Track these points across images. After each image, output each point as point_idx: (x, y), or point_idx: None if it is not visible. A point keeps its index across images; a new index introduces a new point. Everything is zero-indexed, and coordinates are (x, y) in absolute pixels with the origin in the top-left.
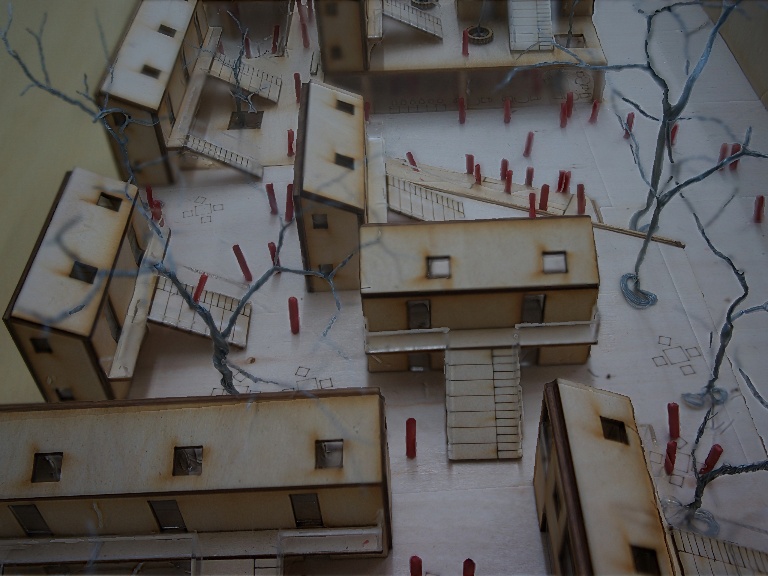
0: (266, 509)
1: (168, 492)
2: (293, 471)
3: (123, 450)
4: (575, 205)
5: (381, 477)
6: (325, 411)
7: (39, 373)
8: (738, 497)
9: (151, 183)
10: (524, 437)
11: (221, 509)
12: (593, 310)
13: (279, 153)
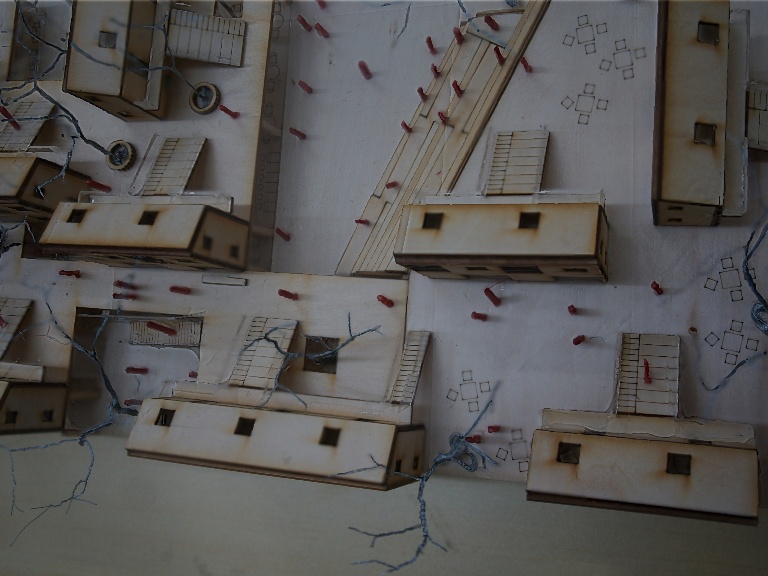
0: None
1: None
2: None
3: None
4: (485, 32)
5: None
6: None
7: None
8: None
9: (422, 449)
10: None
11: None
12: None
13: (386, 316)
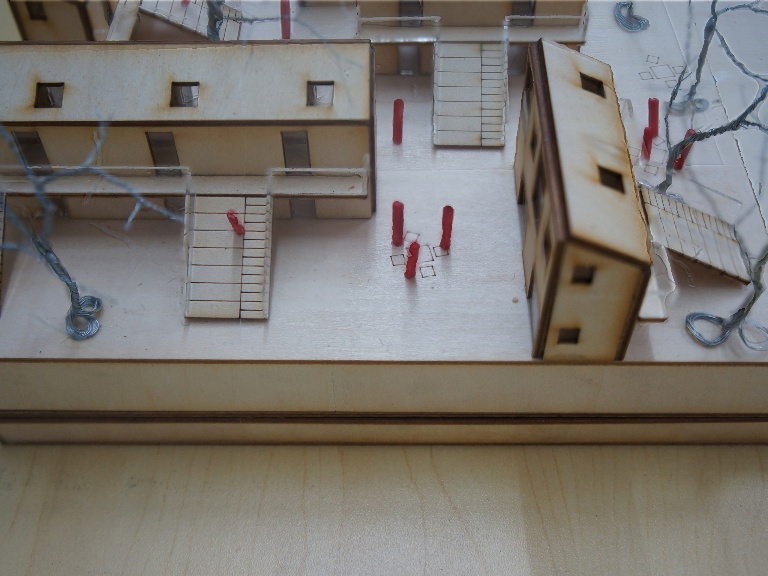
0: (258, 149)
1: (166, 121)
2: (285, 107)
3: (122, 83)
4: None
5: (369, 115)
6: (317, 56)
7: None
8: (708, 184)
9: None
10: (508, 131)
11: (215, 146)
12: (583, 9)
13: None
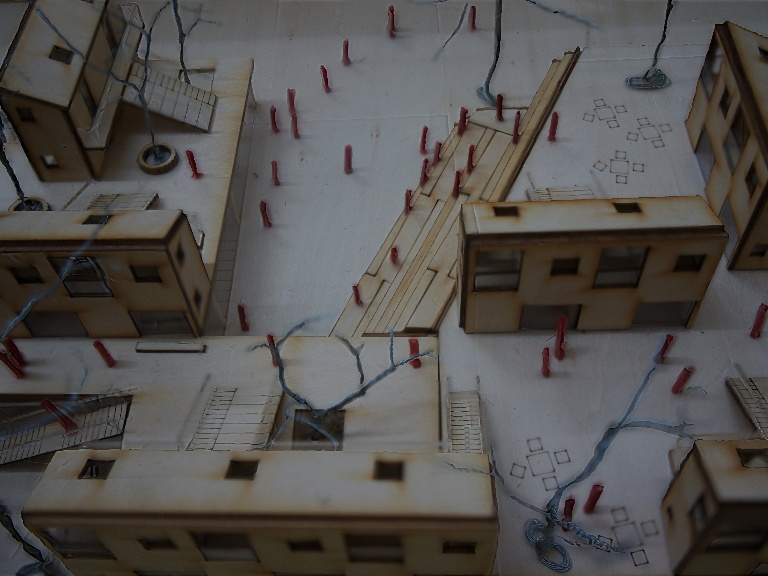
0: None
1: None
2: None
3: None
4: (490, 121)
5: None
6: None
7: None
8: None
9: None
10: None
11: None
12: None
13: (411, 379)
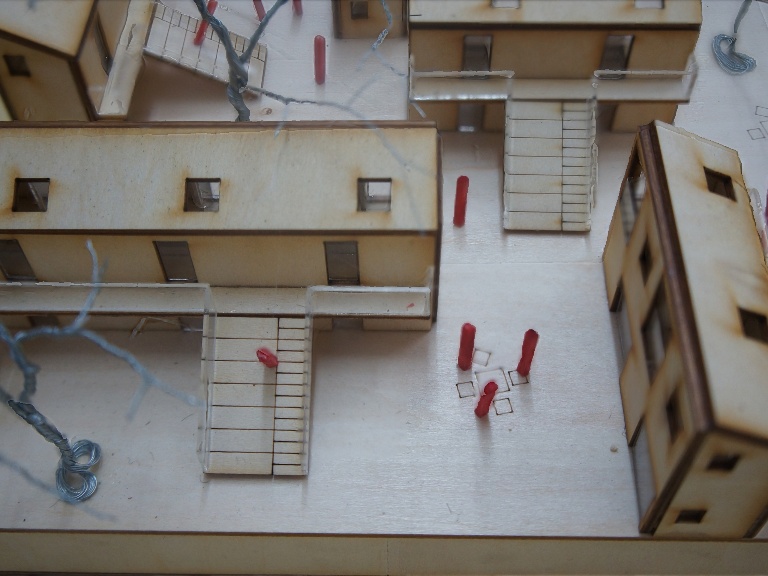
0: (294, 260)
1: (178, 230)
2: (330, 212)
3: (123, 179)
4: None
5: (436, 224)
6: (370, 144)
7: (14, 103)
8: None
9: None
10: (593, 209)
11: (240, 257)
12: (689, 60)
13: None
